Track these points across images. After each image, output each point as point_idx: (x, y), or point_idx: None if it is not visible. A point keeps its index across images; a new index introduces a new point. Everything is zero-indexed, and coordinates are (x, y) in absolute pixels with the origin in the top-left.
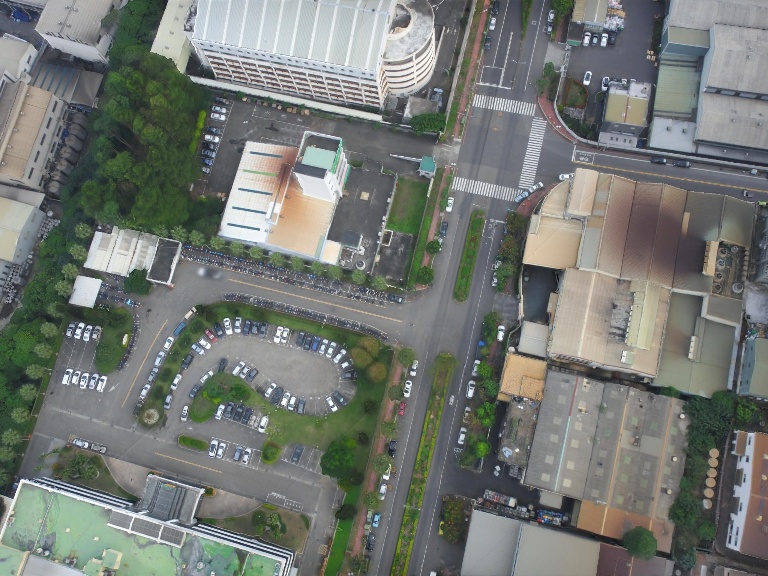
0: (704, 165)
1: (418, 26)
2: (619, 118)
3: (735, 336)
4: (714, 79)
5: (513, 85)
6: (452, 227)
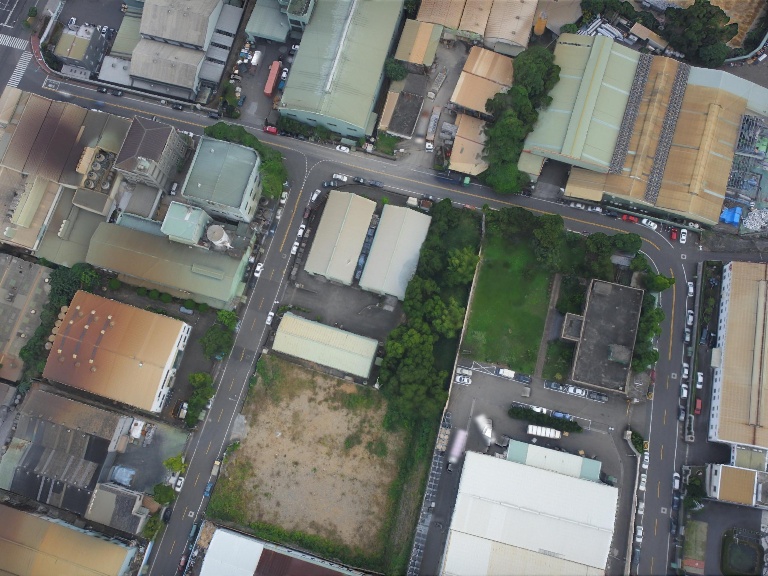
0: (133, 95)
1: None
2: (65, 52)
3: None
4: (145, 27)
5: (15, 24)
6: None
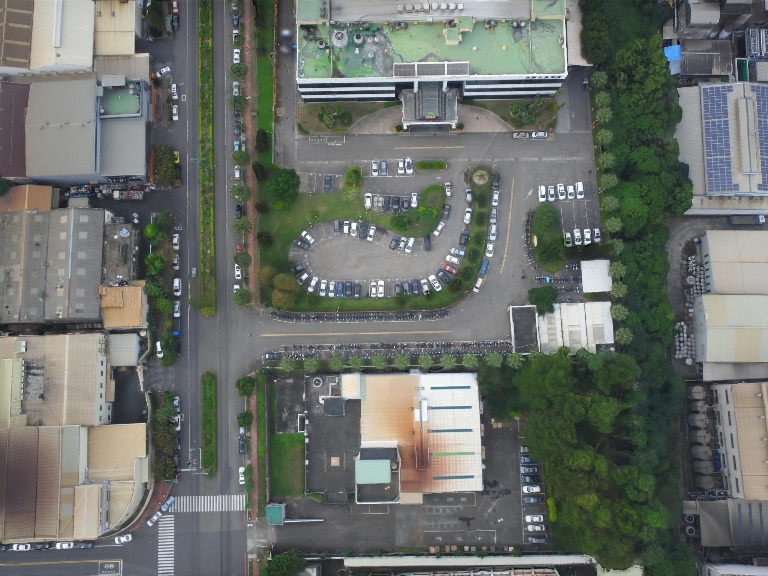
0: None
1: None
2: None
3: None
4: None
5: None
6: (234, 451)
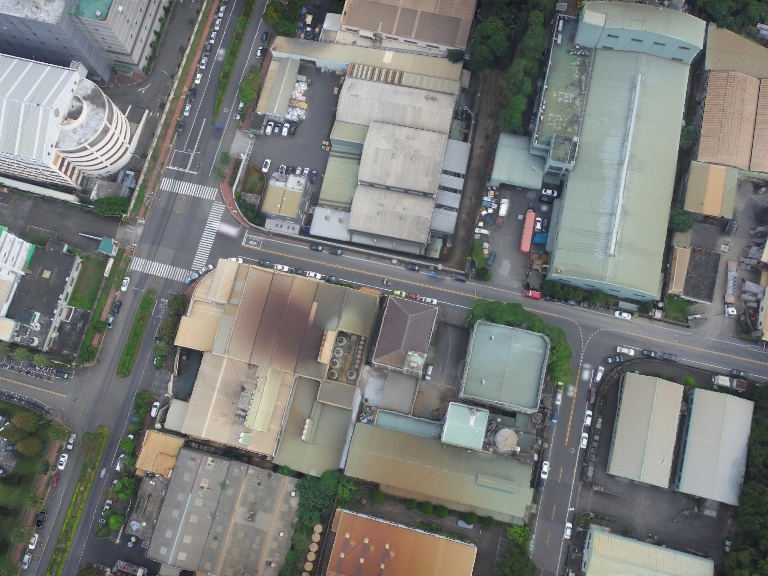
0: (354, 253)
1: (91, 118)
2: (275, 209)
3: (352, 418)
4: (365, 174)
5: (199, 170)
6: (125, 306)
